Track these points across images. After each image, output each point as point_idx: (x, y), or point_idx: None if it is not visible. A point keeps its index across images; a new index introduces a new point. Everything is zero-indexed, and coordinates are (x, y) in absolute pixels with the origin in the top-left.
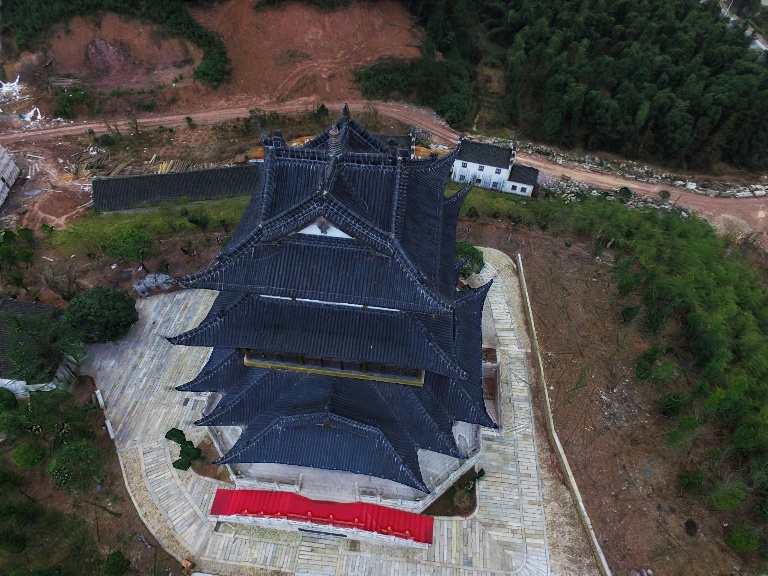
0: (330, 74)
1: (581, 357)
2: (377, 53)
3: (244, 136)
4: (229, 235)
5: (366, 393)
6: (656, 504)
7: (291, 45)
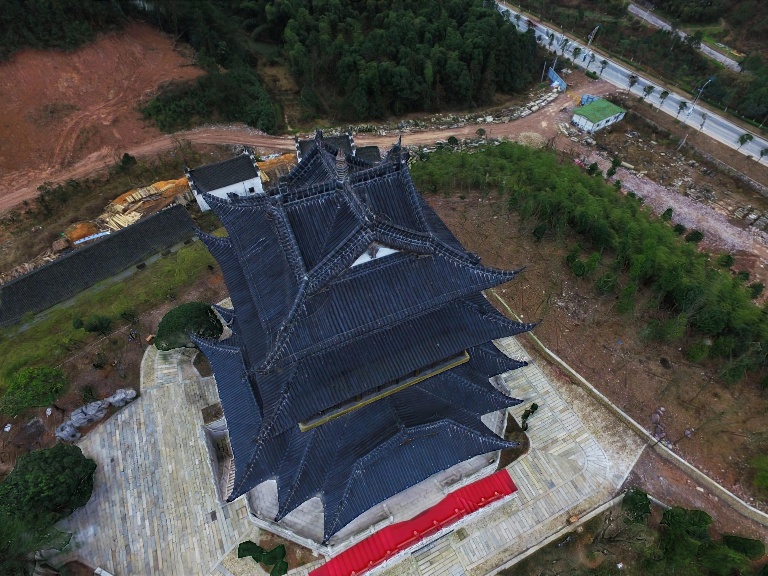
0: (112, 119)
1: (527, 282)
2: (154, 82)
3: (47, 219)
4: (135, 326)
5: (414, 396)
6: (638, 360)
7: (45, 100)
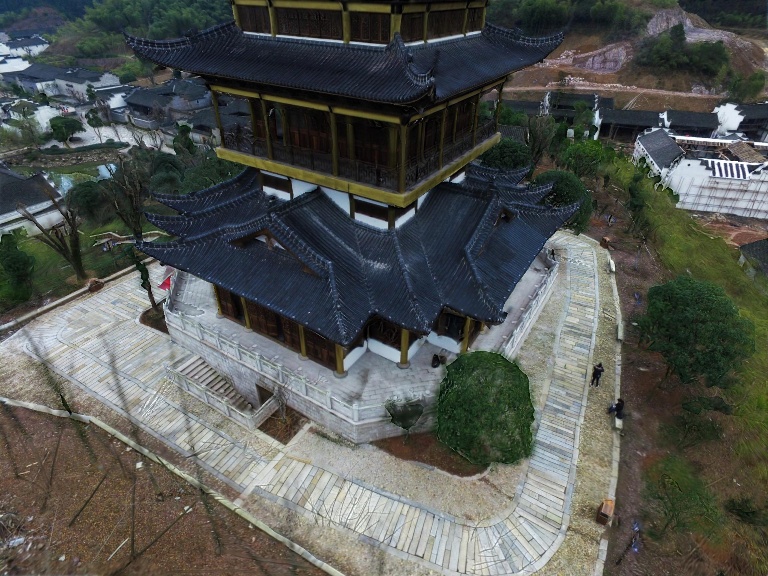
0: None
1: (115, 567)
2: None
3: None
4: None
5: None
6: None
7: None
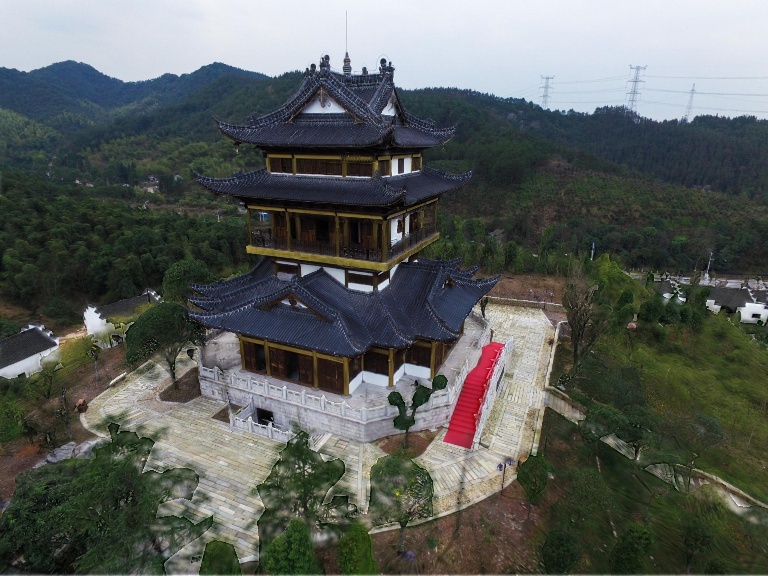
0: None
1: None
2: None
3: None
4: (39, 412)
5: None
6: None
7: None
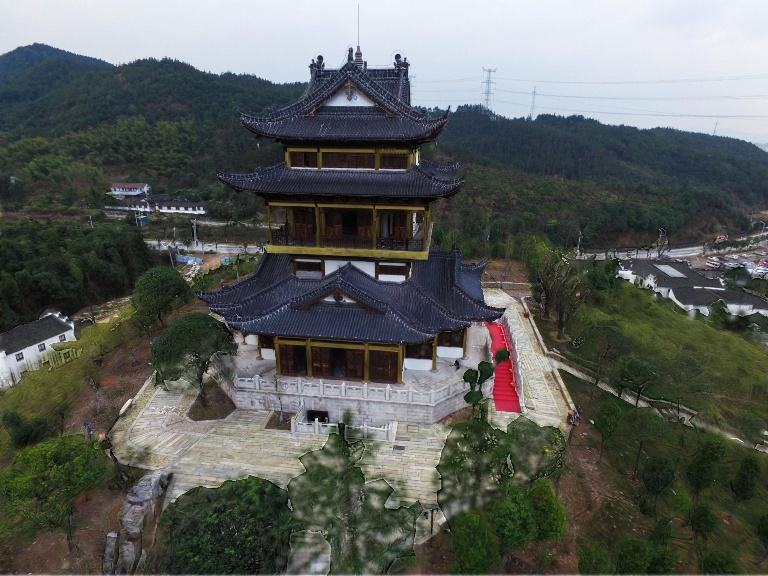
0: None
1: None
2: None
3: None
4: None
5: None
6: None
7: None
